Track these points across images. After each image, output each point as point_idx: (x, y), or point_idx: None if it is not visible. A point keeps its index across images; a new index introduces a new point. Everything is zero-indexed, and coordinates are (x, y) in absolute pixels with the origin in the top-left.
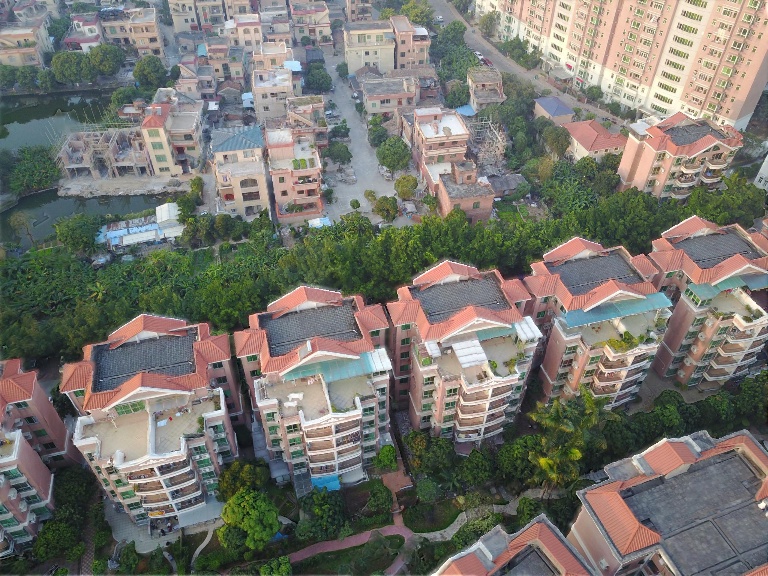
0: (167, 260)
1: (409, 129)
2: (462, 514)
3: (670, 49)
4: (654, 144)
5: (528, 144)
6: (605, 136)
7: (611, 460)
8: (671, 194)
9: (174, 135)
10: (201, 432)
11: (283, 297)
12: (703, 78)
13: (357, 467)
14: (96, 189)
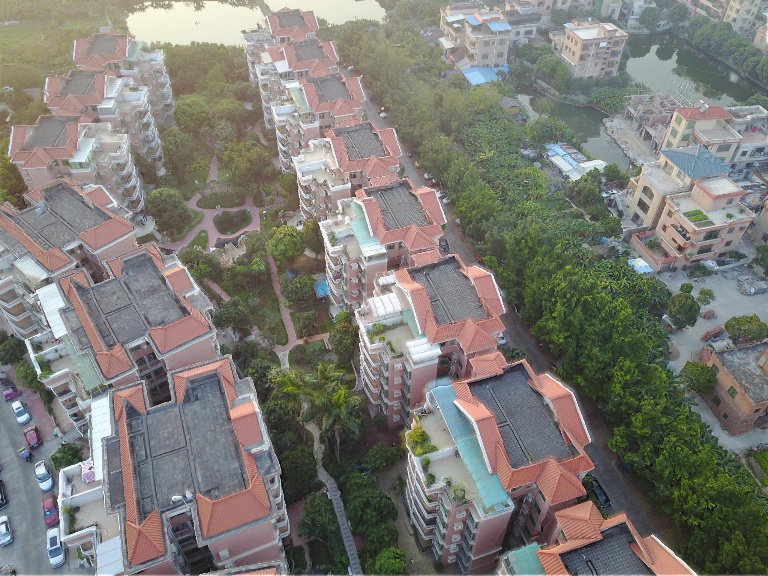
0: (535, 179)
1: None
2: None
3: None
4: None
5: None
6: None
7: None
8: None
9: None
10: (315, 182)
11: None
12: None
13: None
14: (618, 132)
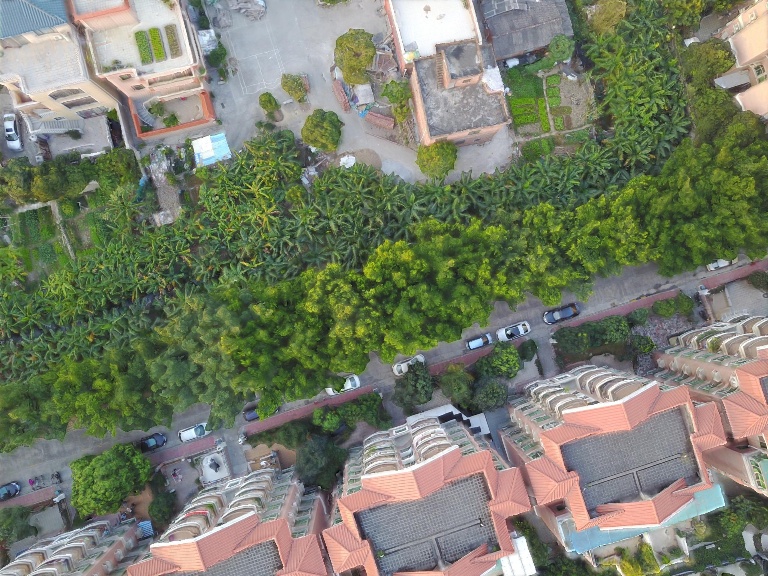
0: None
1: None
2: None
3: None
4: None
5: None
6: None
7: (586, 575)
8: None
9: None
10: None
11: (169, 545)
12: None
13: None
14: None
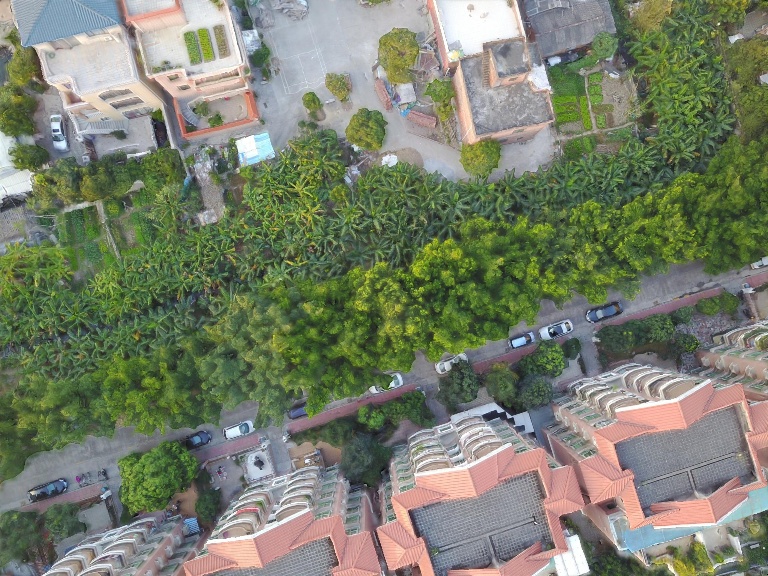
0: (28, 265)
1: None
2: None
3: None
4: None
5: None
6: None
7: None
8: None
9: None
10: None
11: (226, 541)
12: None
13: None
14: None
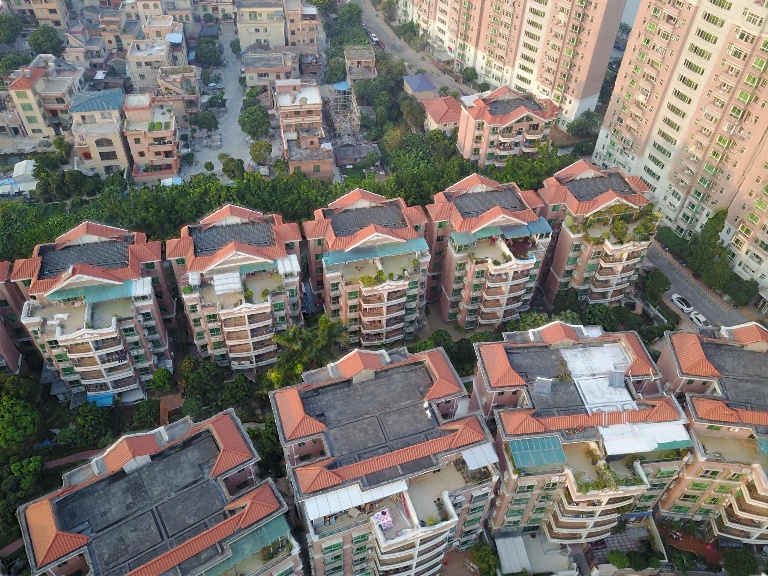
0: (13, 210)
1: (274, 99)
2: None
3: (525, 32)
4: (473, 114)
5: (392, 118)
6: (455, 110)
7: None
8: (494, 162)
9: (45, 98)
10: None
11: None
12: (551, 59)
13: (133, 387)
14: None
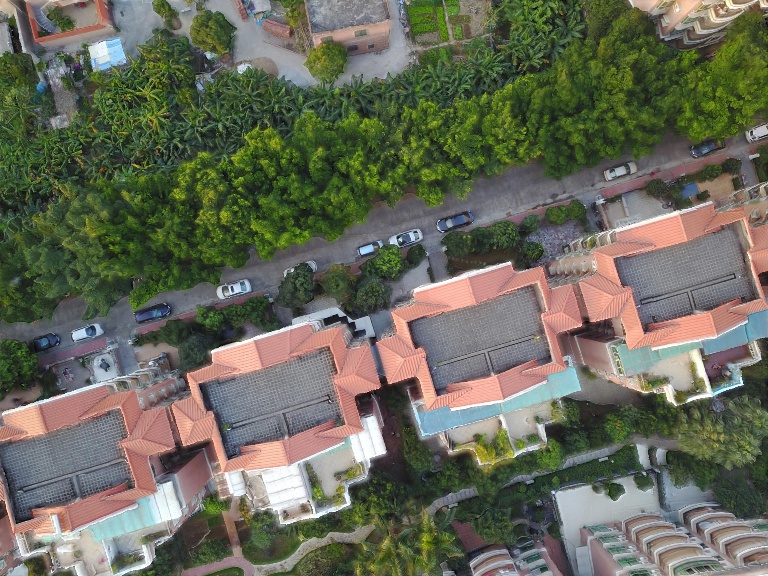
0: None
1: None
2: (304, 544)
3: None
4: None
5: None
6: None
7: None
8: (695, 23)
9: None
10: None
11: (17, 410)
12: None
13: None
14: None
